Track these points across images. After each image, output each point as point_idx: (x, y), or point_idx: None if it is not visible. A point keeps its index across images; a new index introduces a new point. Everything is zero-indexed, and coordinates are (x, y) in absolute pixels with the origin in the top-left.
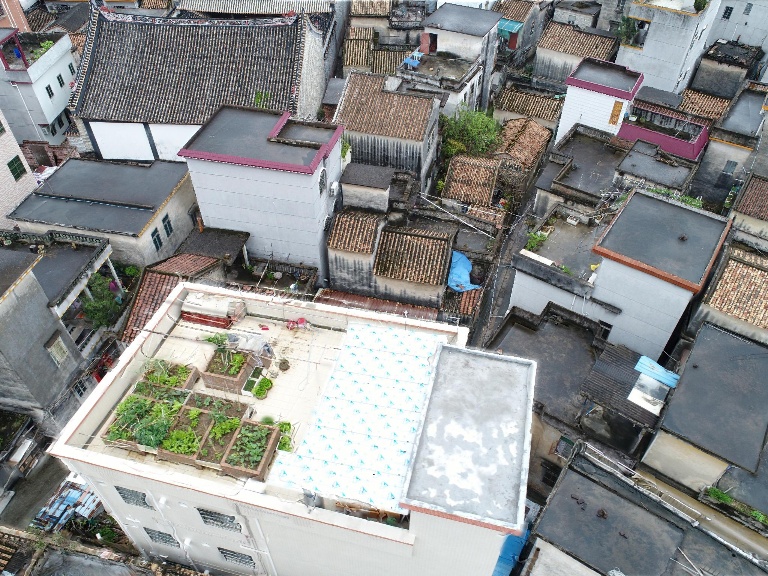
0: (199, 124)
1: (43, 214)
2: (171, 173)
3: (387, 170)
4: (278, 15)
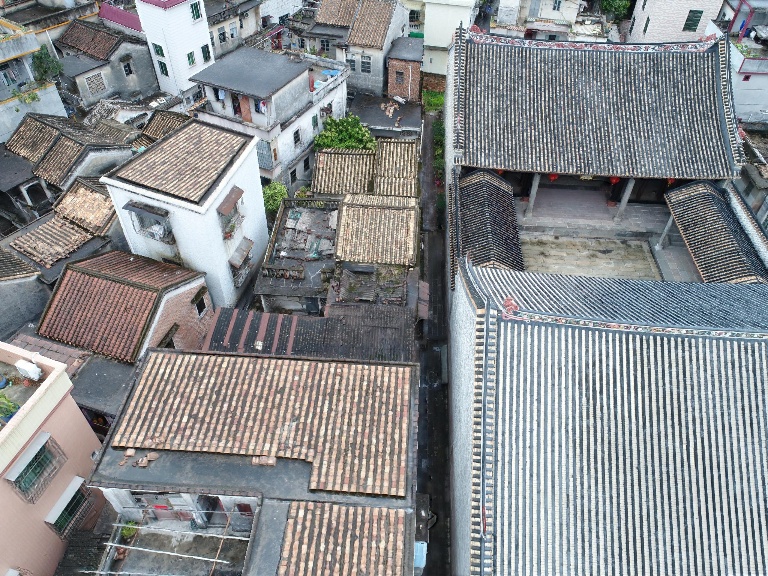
0: None
1: None
2: None
3: None
4: None
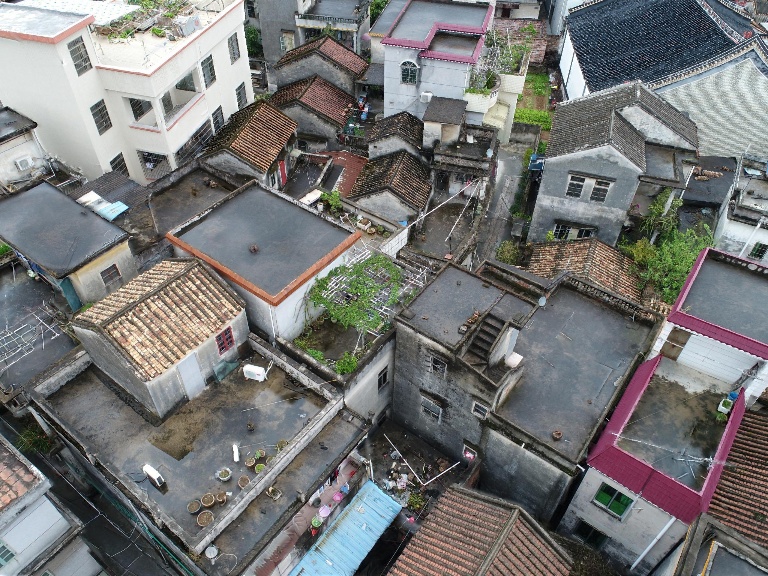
0: None
1: (395, 6)
2: None
3: (455, 119)
4: None
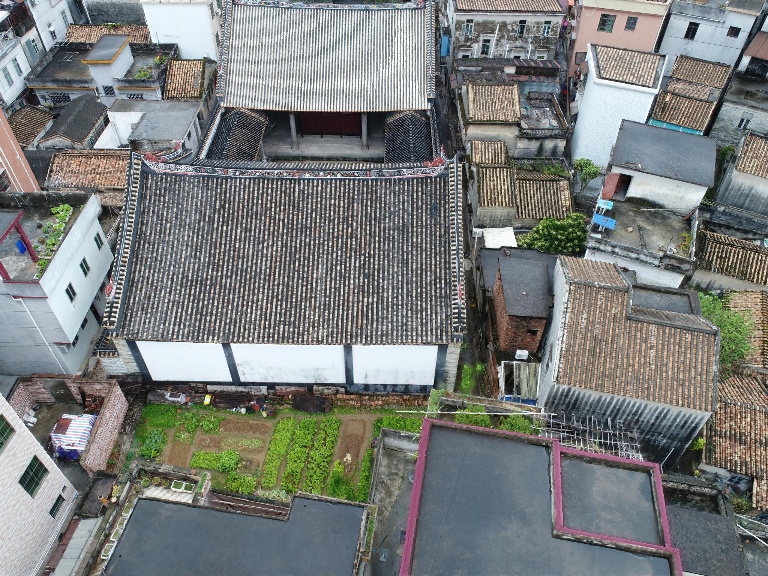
0: (311, 344)
1: None
2: (331, 537)
3: (721, 524)
4: (357, 112)
